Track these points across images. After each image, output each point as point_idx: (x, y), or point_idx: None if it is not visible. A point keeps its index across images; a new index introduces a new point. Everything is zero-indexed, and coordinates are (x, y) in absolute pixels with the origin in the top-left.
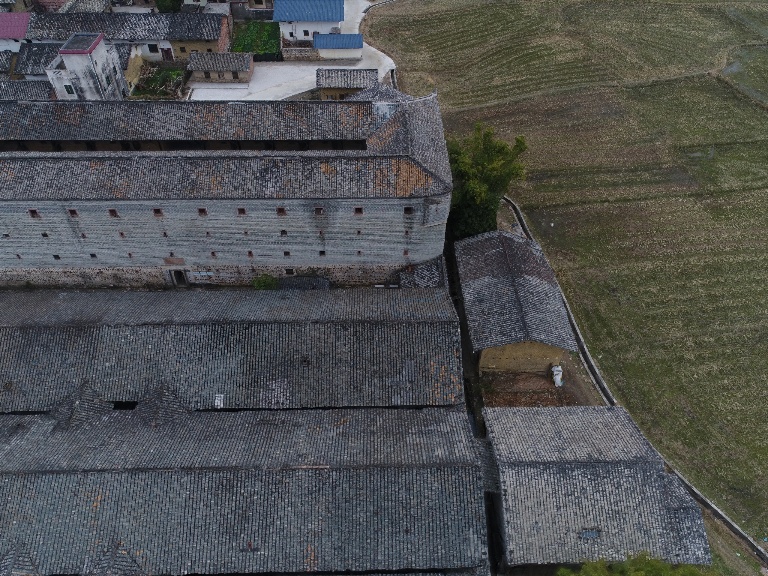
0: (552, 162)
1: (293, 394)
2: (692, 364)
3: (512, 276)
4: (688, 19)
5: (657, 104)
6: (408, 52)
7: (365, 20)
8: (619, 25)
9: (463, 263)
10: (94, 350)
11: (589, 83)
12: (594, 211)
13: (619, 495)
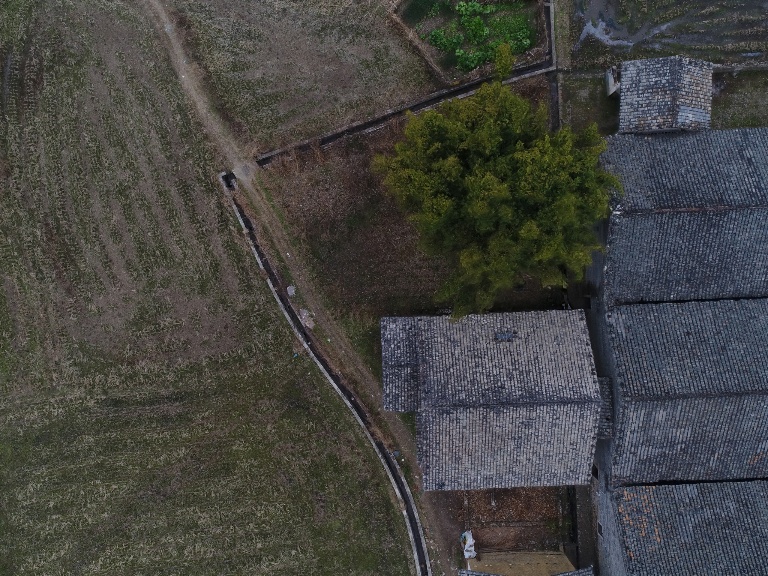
0: None
1: None
2: (291, 571)
3: None
4: None
5: None
6: None
7: None
8: None
9: None
10: None
11: None
12: None
13: (473, 373)
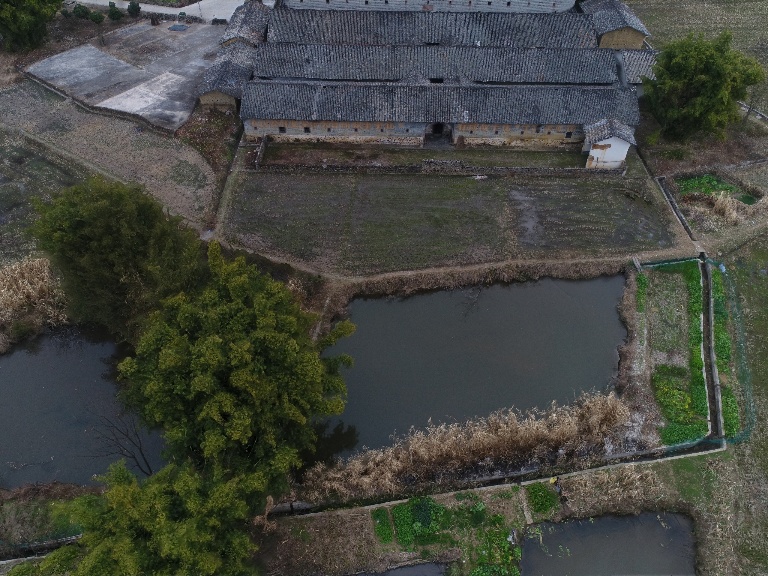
0: None
1: (514, 42)
2: None
3: (615, 8)
4: None
5: None
6: None
7: None
8: None
9: (586, 9)
10: (415, 22)
11: None
12: (654, 8)
13: None
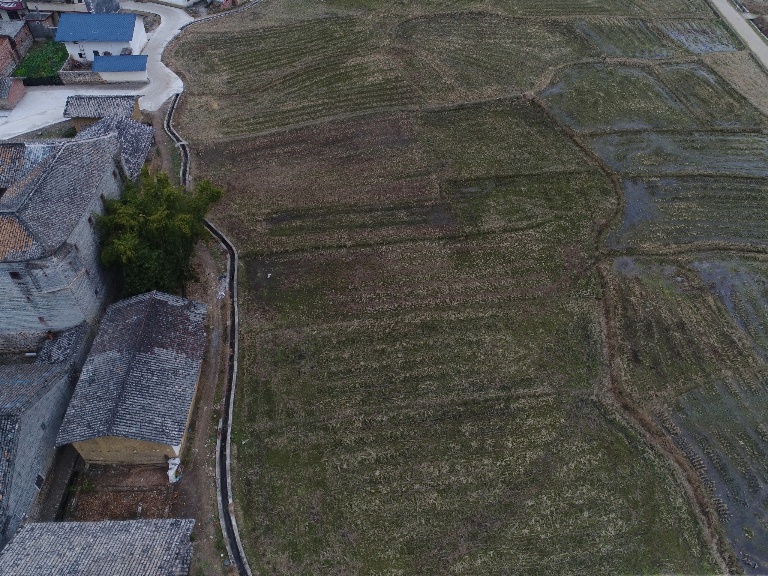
0: (303, 200)
1: None
2: (348, 450)
3: (134, 351)
4: (530, 34)
5: (453, 131)
6: (206, 73)
7: (177, 38)
8: (452, 41)
9: (102, 332)
10: None
11: (387, 107)
12: (324, 258)
13: None
